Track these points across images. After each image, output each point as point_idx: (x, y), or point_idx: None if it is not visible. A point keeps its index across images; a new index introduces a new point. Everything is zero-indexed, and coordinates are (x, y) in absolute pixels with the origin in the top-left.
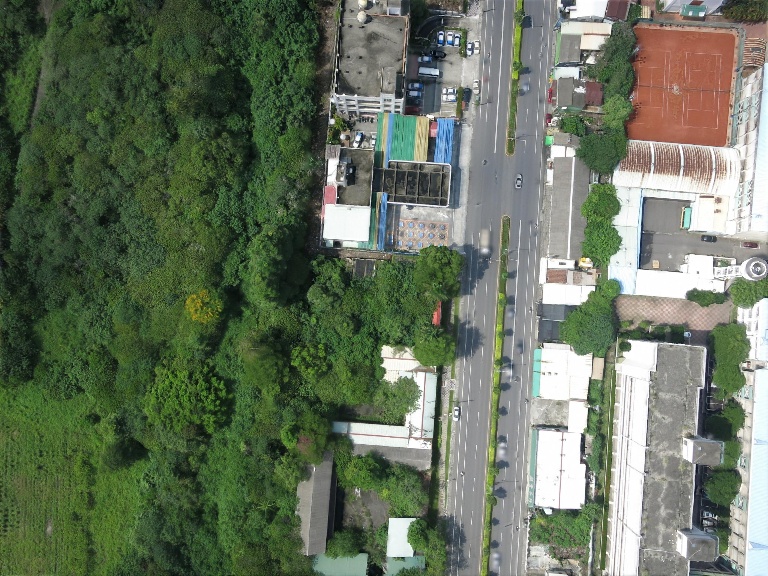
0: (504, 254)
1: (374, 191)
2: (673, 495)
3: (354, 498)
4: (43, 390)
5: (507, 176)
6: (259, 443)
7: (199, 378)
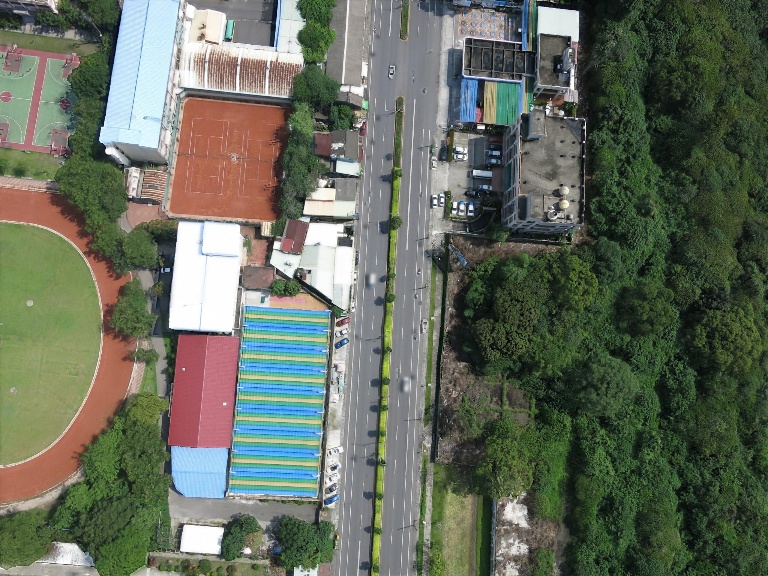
0: (406, 5)
1: (534, 54)
2: None
3: None
4: None
5: (403, 77)
6: None
7: None
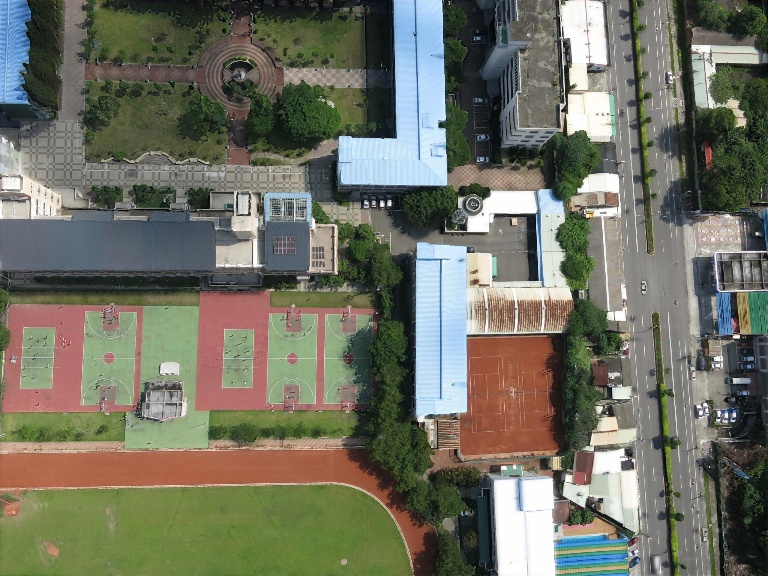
0: (649, 220)
1: None
2: (530, 1)
3: (741, 5)
4: None
5: (655, 292)
6: None
7: None
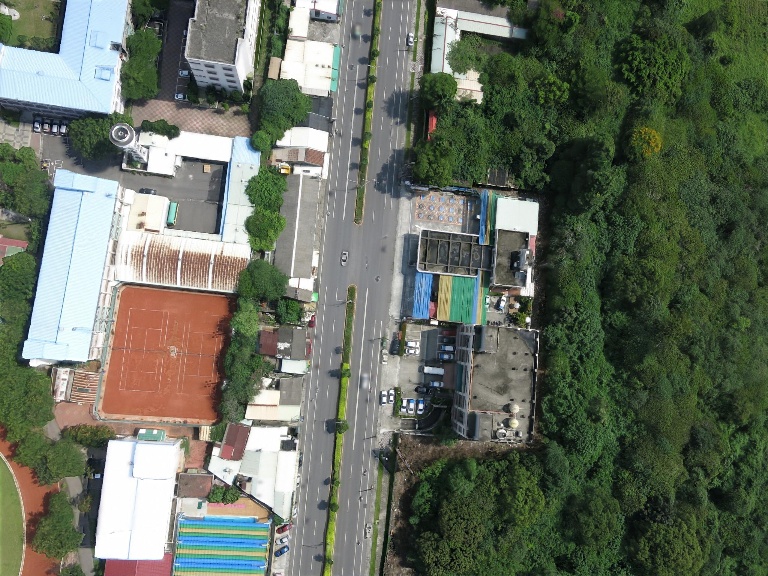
0: (362, 186)
1: (491, 248)
2: None
3: None
4: (767, 86)
5: (356, 264)
6: (593, 21)
7: (647, 80)
